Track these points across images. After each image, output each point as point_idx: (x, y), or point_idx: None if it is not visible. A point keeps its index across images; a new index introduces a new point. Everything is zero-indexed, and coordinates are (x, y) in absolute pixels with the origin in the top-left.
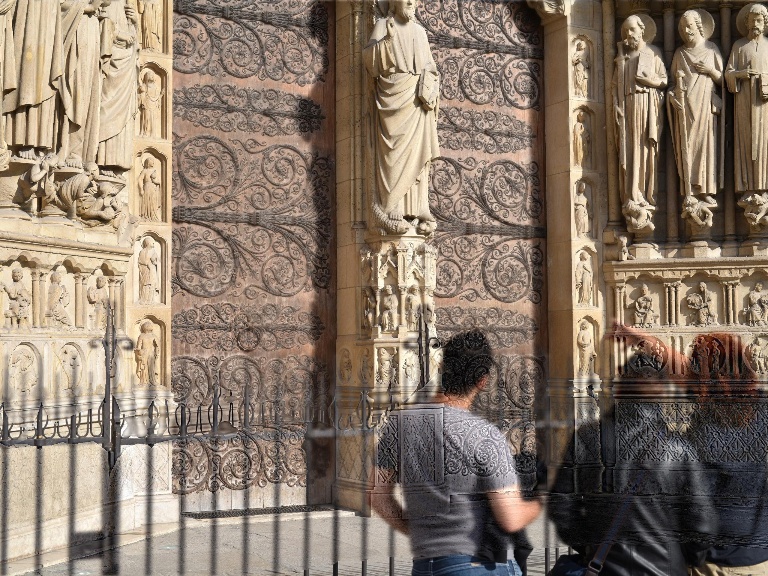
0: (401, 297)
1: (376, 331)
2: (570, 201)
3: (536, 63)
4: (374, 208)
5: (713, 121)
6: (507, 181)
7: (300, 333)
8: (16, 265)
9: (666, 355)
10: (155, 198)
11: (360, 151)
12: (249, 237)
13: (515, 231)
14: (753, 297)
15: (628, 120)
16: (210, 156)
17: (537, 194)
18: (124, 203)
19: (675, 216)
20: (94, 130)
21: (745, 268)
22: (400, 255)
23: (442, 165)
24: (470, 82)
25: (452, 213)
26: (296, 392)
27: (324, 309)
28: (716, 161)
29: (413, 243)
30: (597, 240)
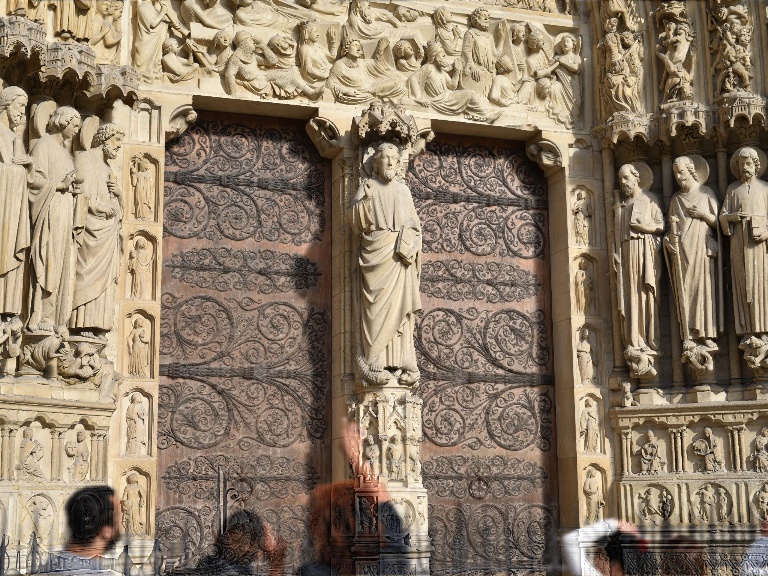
0: (382, 447)
1: (358, 481)
2: (572, 348)
3: (540, 214)
4: (358, 360)
5: (710, 264)
6: (511, 330)
7: (295, 483)
8: None
9: (673, 503)
10: (143, 356)
11: (349, 305)
12: (244, 390)
13: (520, 379)
14: (759, 442)
15: (625, 266)
16: (206, 315)
17: (544, 342)
18: (109, 361)
19: (679, 360)
20: (65, 296)
21: (749, 412)
22: (380, 405)
23: (442, 316)
24: (471, 235)
25: (453, 363)
26: (290, 541)
27: (319, 459)
28: (715, 304)
29: (396, 393)
30: (602, 386)
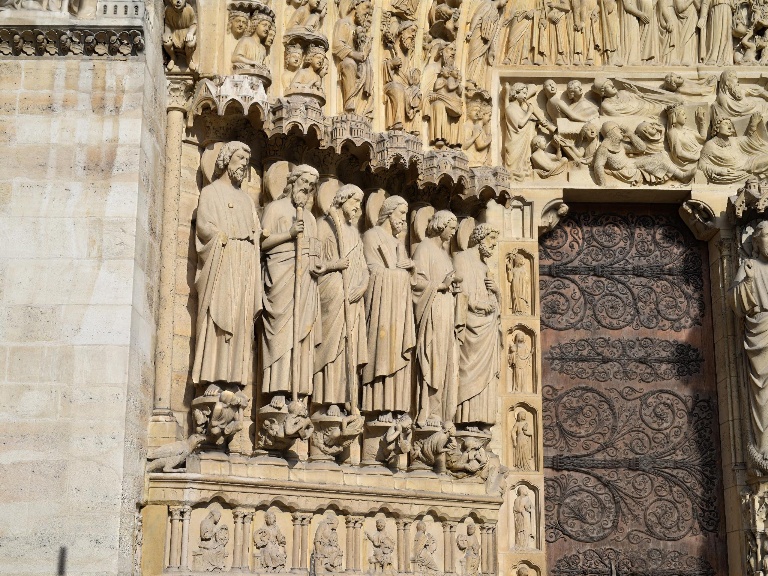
0: None
1: None
2: None
3: None
4: (749, 449)
5: None
6: None
7: None
8: (380, 516)
9: None
10: (527, 449)
11: (736, 391)
12: (630, 482)
13: None
14: None
15: None
16: (587, 406)
17: None
18: (495, 455)
19: None
20: (450, 392)
21: None
22: None
23: None
24: None
25: None
26: None
27: (714, 553)
28: None
29: None
30: None
